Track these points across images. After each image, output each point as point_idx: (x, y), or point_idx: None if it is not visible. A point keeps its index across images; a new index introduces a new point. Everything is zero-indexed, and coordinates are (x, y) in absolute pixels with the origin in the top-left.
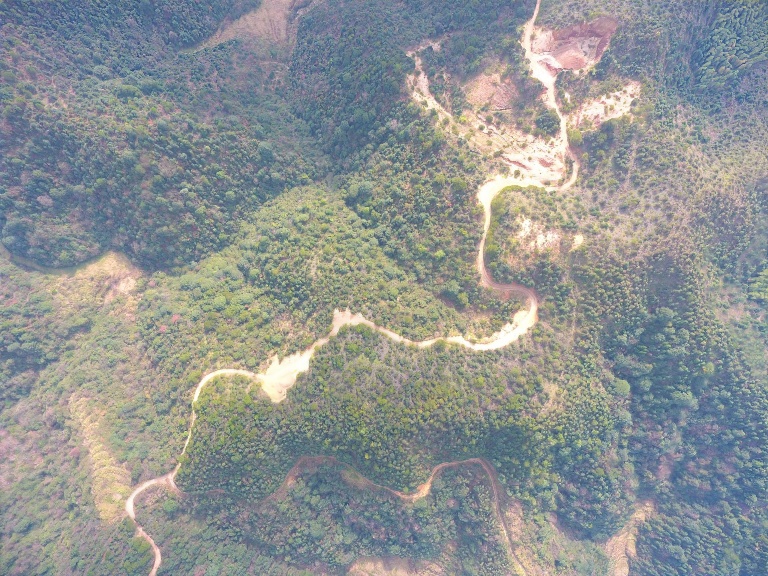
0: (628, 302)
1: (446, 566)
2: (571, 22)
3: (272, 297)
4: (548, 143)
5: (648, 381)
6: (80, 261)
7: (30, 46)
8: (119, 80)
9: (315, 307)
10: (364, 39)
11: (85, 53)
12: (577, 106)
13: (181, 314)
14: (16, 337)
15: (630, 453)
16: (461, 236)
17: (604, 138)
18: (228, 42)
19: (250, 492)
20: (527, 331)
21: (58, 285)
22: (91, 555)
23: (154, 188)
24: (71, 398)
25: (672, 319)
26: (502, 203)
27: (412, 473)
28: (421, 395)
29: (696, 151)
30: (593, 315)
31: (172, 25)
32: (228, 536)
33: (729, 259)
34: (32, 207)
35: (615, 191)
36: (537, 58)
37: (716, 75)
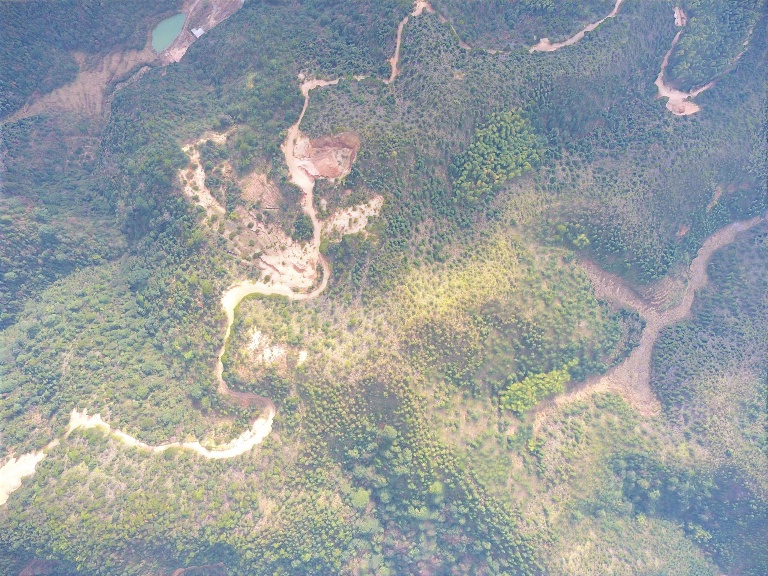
0: (346, 422)
1: None
2: (320, 133)
3: (32, 386)
4: (303, 248)
5: (386, 494)
6: None
7: None
8: None
9: (60, 404)
10: None
11: None
12: (331, 214)
13: None
14: None
15: (387, 558)
16: (204, 341)
17: (341, 252)
18: (31, 118)
19: None
20: (261, 441)
21: None
22: None
23: None
24: None
25: (396, 438)
26: (240, 312)
27: None
28: (132, 509)
29: (425, 272)
30: (313, 433)
31: None
32: None
33: (466, 376)
34: None
35: (348, 306)
36: (297, 163)
37: (475, 188)
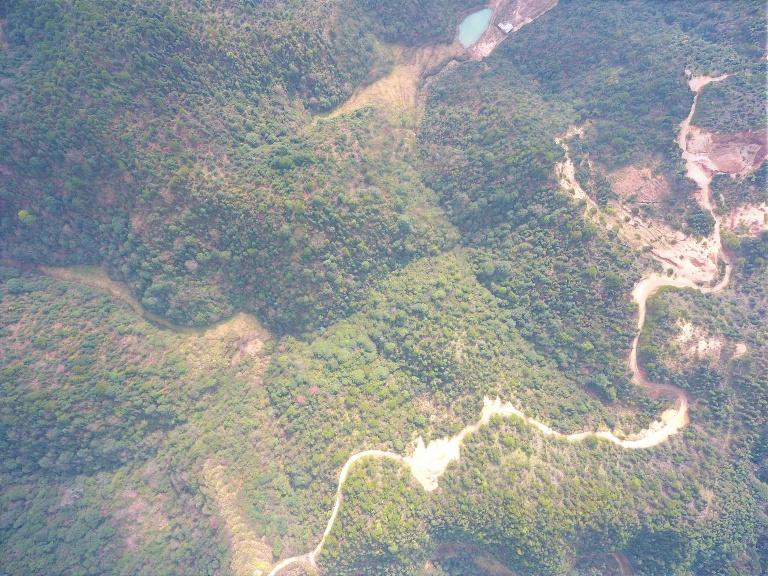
0: None
1: None
2: (735, 129)
3: (410, 374)
4: (700, 243)
5: None
6: (212, 322)
7: (192, 114)
8: (267, 147)
9: (461, 391)
10: (509, 121)
11: (240, 121)
12: (732, 209)
13: (319, 386)
14: (154, 399)
15: (756, 550)
16: (614, 332)
17: (766, 247)
18: (364, 109)
19: None
20: (677, 432)
21: (190, 345)
22: None
23: (302, 260)
24: (206, 464)
25: None
26: None
27: (558, 568)
28: (580, 495)
29: None
30: (752, 425)
31: (314, 91)
32: None
33: None
34: (178, 270)
35: None
36: (692, 158)
37: None
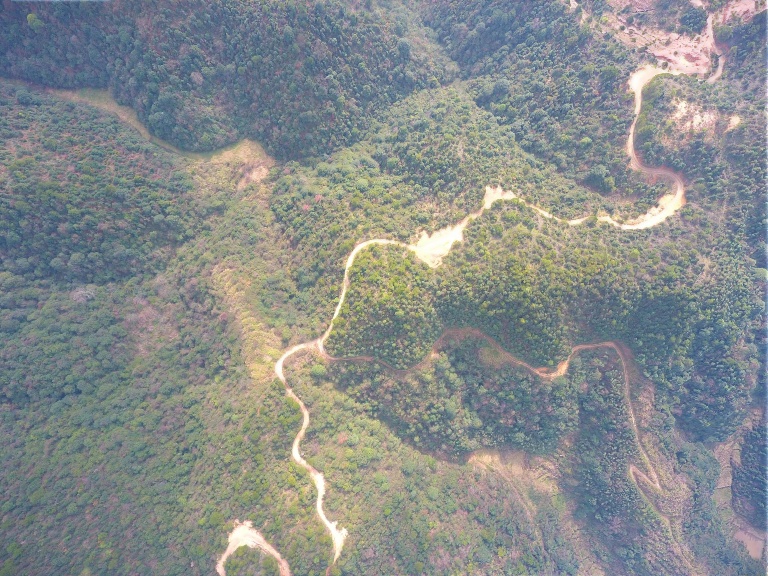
0: None
1: (561, 463)
2: None
3: (413, 182)
4: (693, 39)
5: None
6: (218, 146)
7: None
8: None
9: (463, 186)
10: None
11: None
12: (723, 4)
13: (324, 194)
14: (162, 209)
15: None
16: (611, 121)
17: (757, 29)
18: None
19: (401, 357)
20: (674, 213)
21: (197, 167)
22: (245, 410)
23: (305, 70)
24: (214, 270)
25: None
26: (656, 88)
27: (560, 344)
28: (581, 261)
29: None
30: (747, 193)
31: None
32: (364, 411)
33: None
34: (183, 84)
35: (767, 79)
36: None
37: None
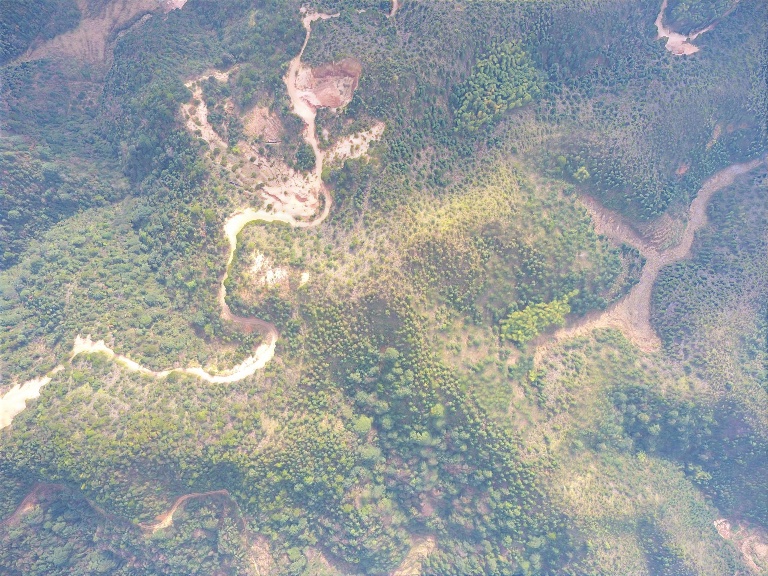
0: (348, 342)
1: None
2: (322, 61)
3: (36, 319)
4: (305, 178)
5: (388, 419)
6: None
7: None
8: None
9: (64, 332)
10: None
11: None
12: (333, 143)
13: None
14: None
15: (389, 489)
16: (207, 267)
17: (343, 177)
18: (34, 61)
19: None
20: (264, 365)
21: None
22: None
23: None
24: None
25: (398, 360)
26: (242, 237)
27: (138, 505)
28: (136, 427)
29: (426, 194)
30: (316, 353)
31: None
32: None
33: (467, 301)
34: None
35: (350, 230)
36: (299, 94)
37: (475, 119)
